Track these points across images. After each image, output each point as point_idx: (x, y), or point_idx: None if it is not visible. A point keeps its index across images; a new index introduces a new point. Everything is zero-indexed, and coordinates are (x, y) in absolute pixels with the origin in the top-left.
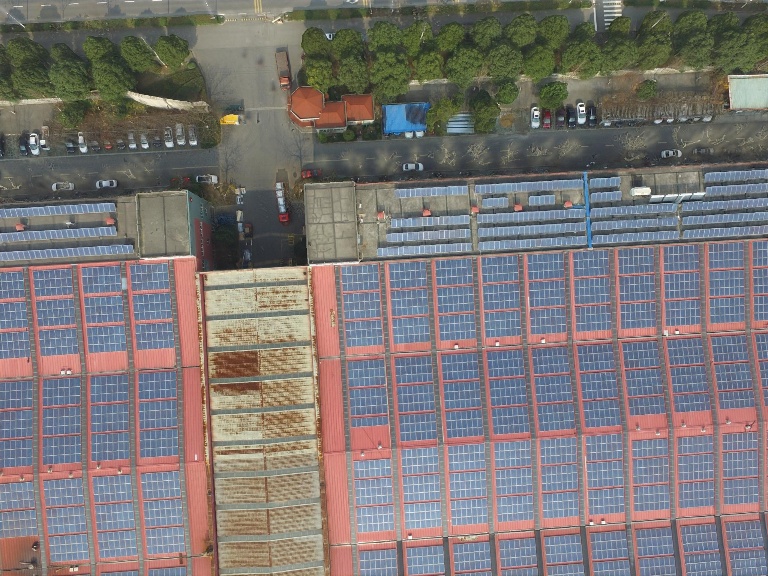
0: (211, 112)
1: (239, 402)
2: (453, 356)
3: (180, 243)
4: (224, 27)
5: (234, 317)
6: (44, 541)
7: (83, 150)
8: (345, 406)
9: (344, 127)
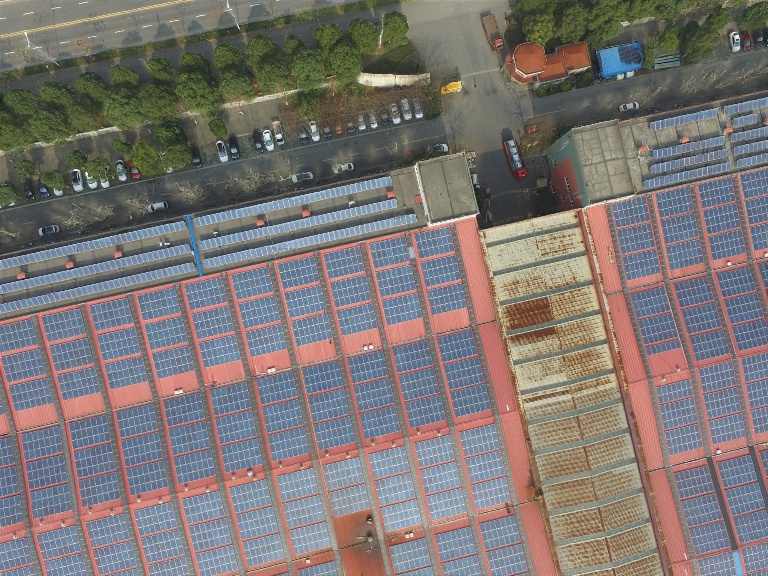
0: (431, 84)
1: (538, 349)
2: (728, 273)
3: (465, 203)
4: (427, 1)
5: (519, 268)
6: (377, 513)
7: (316, 139)
8: (637, 336)
9: (566, 77)
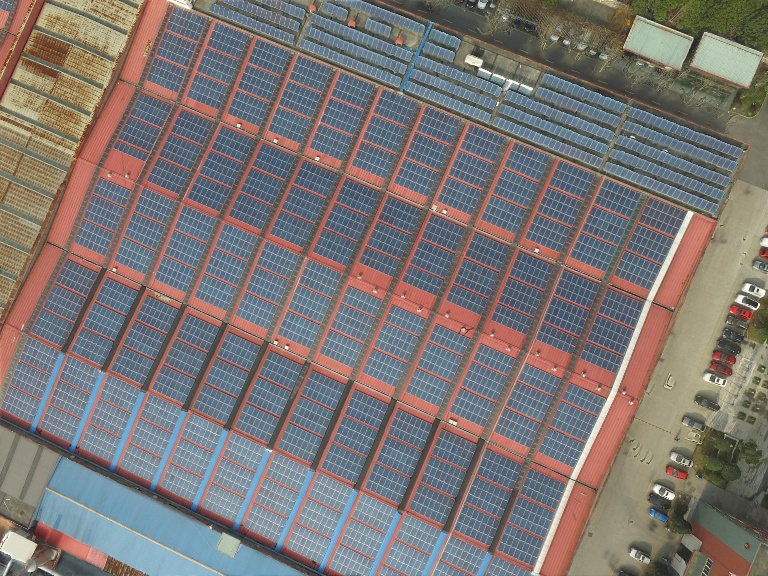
0: None
1: (35, 81)
2: (232, 132)
3: None
4: None
5: (68, 9)
6: None
7: None
8: (118, 128)
9: None
